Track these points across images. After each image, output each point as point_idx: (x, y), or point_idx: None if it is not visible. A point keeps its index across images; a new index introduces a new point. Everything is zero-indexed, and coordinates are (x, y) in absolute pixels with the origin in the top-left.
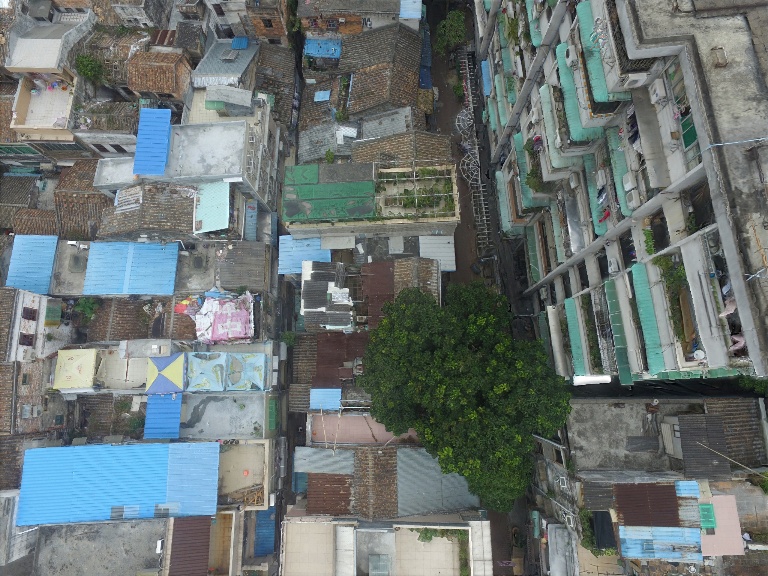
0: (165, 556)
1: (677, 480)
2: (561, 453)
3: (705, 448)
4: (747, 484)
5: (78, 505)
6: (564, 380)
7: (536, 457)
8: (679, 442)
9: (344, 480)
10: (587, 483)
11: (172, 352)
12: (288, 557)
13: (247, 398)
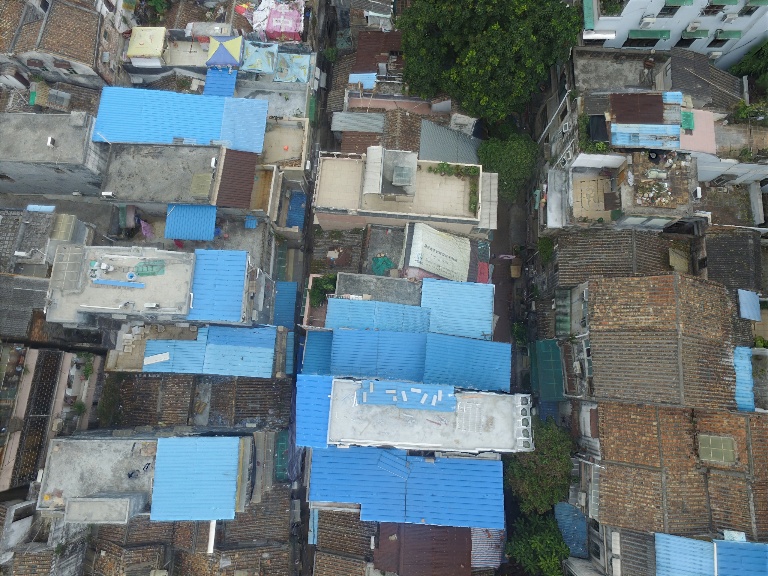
0: (217, 173)
1: (665, 91)
2: (566, 101)
3: (691, 74)
4: (725, 122)
5: (145, 132)
6: (576, 9)
7: (542, 155)
8: (669, 76)
9: (374, 137)
10: (587, 96)
11: (231, 35)
12: (322, 187)
13: (291, 94)
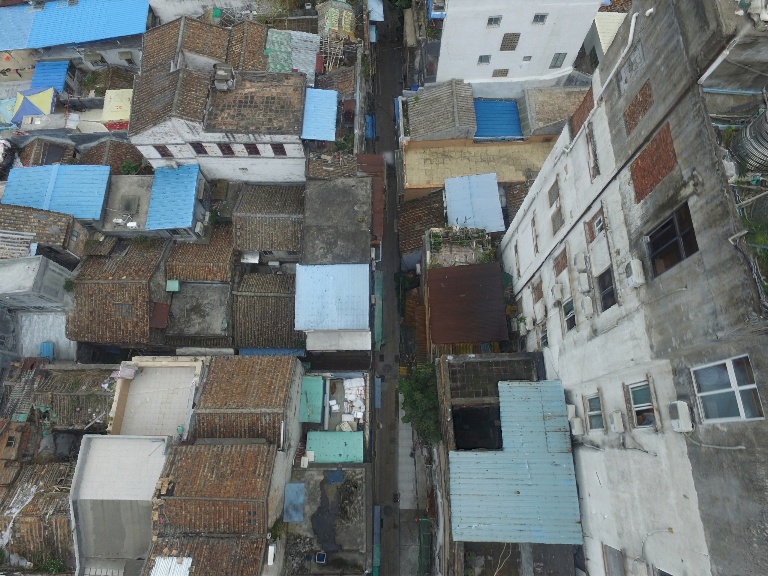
0: None
1: None
2: None
3: None
4: None
5: (103, 3)
6: None
7: None
8: None
9: None
10: None
11: None
12: None
13: None
